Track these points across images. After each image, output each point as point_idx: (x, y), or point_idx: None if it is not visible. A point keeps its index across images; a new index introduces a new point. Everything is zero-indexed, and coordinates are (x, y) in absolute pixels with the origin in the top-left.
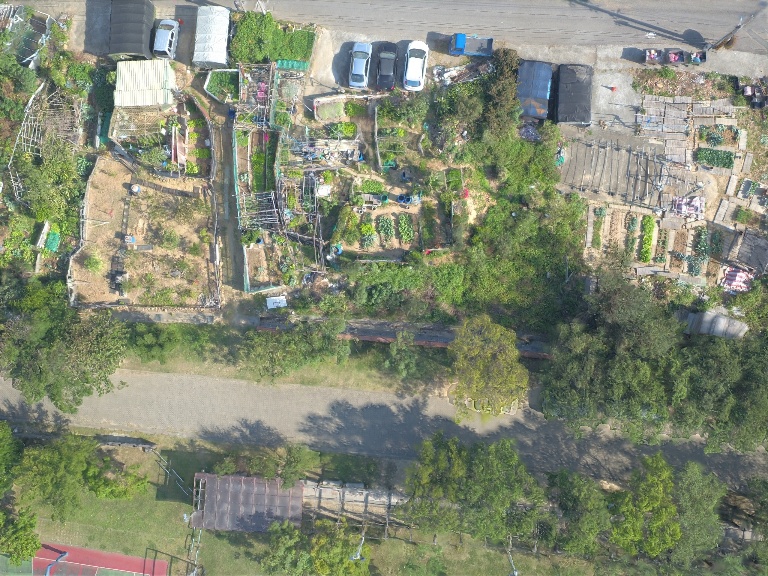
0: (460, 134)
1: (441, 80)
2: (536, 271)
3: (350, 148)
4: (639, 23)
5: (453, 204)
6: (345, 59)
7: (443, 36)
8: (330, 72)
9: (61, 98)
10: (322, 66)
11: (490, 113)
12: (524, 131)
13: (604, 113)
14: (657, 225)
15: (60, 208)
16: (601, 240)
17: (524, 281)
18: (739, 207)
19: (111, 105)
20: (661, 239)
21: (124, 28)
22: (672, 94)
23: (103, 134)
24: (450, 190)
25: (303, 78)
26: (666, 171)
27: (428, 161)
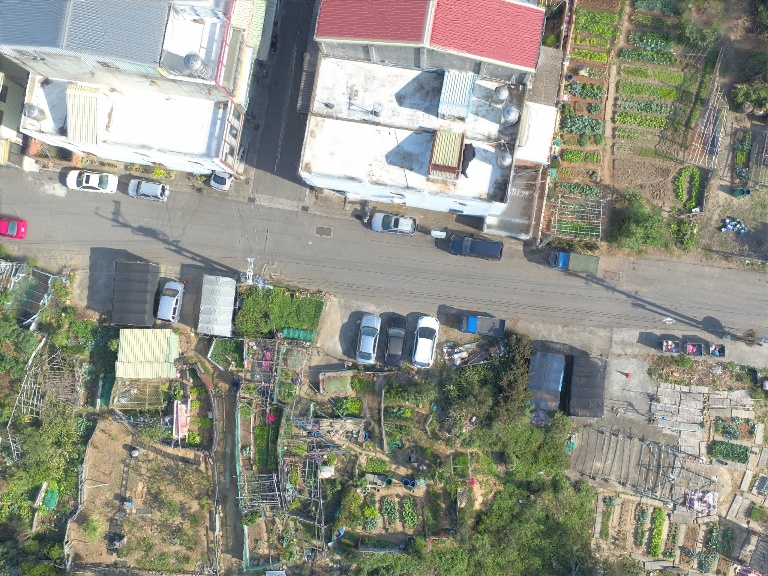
0: (468, 420)
1: (451, 358)
2: (542, 561)
3: (355, 429)
4: (657, 307)
5: (459, 491)
6: (353, 329)
7: (454, 310)
8: (337, 342)
9: (62, 360)
10: (329, 335)
11: (500, 406)
12: (534, 415)
13: (617, 399)
14: (668, 518)
15: (59, 468)
16: (610, 531)
17: (529, 570)
18: (753, 504)
19: (113, 365)
20: (671, 533)
21: (127, 297)
22: (688, 383)
23: (104, 395)
24: (456, 480)
25: (309, 349)
26: (679, 463)
27: (435, 443)
